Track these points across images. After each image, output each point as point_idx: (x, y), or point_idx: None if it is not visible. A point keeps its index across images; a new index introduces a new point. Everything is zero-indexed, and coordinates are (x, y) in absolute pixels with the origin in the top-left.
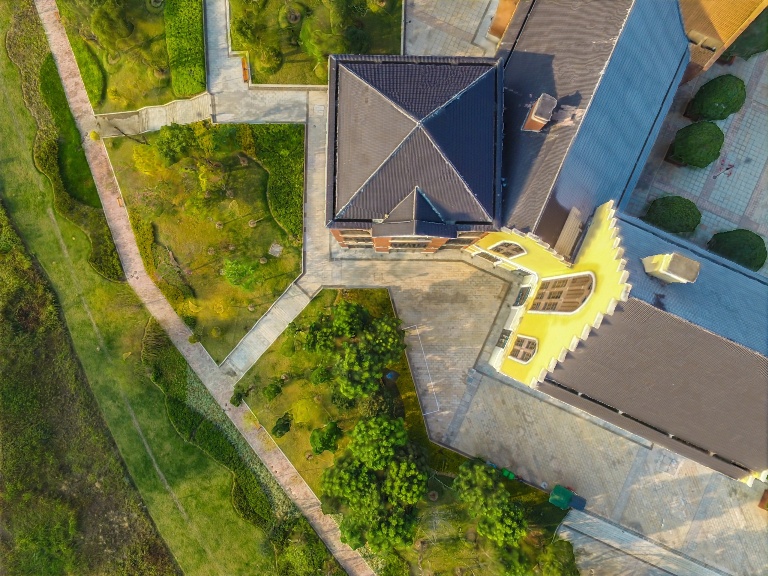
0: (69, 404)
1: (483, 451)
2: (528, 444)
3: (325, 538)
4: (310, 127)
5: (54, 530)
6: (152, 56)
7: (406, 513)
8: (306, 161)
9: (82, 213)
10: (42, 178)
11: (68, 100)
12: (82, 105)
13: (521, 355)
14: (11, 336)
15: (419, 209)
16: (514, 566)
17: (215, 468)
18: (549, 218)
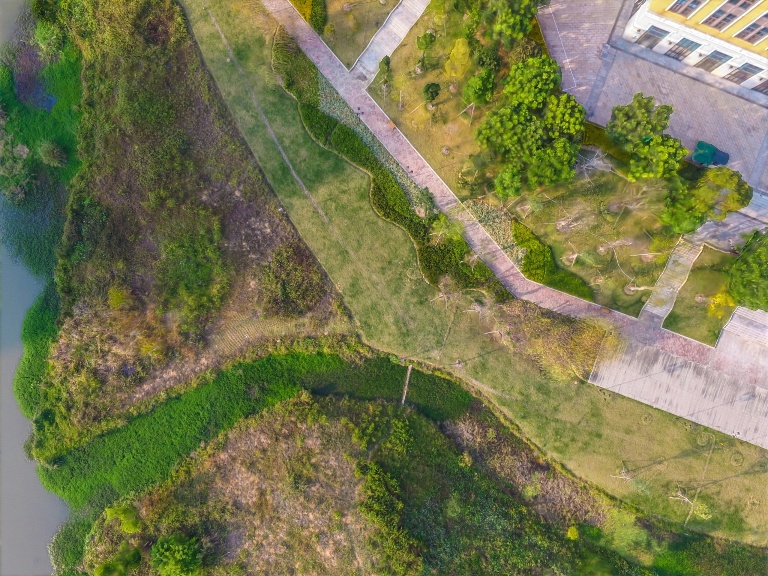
0: (204, 115)
1: None
2: None
3: (464, 233)
4: None
5: (198, 238)
6: None
7: None
8: None
9: None
10: None
11: None
12: None
13: None
14: (143, 47)
15: None
16: (676, 189)
17: (352, 171)
18: None
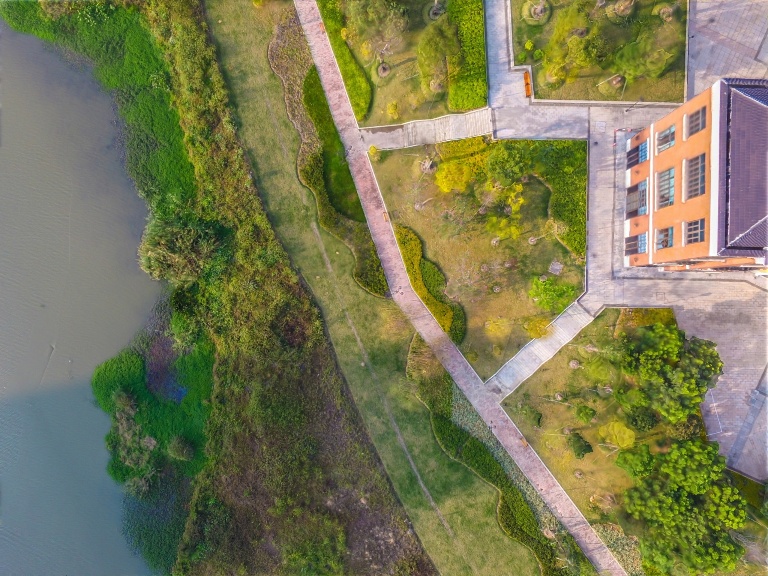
0: (334, 419)
1: (766, 473)
2: None
3: (591, 557)
4: (592, 144)
5: (321, 545)
6: None
7: (729, 538)
8: (588, 178)
9: (347, 227)
10: (306, 192)
11: (332, 113)
12: (346, 118)
13: None
14: (280, 351)
15: None
16: None
17: (480, 485)
18: None
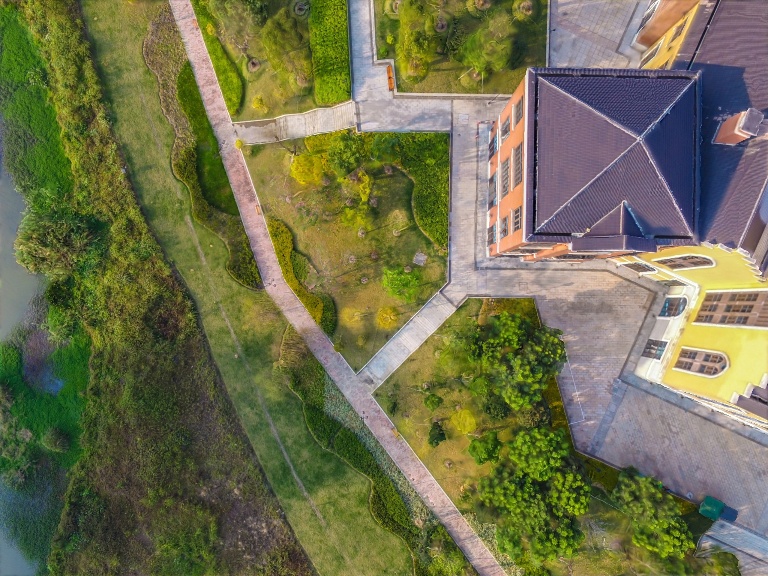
0: (208, 411)
1: (628, 461)
2: (673, 454)
3: (462, 546)
4: (455, 136)
5: (194, 536)
6: (294, 64)
7: (572, 524)
8: (451, 170)
9: (220, 221)
10: (180, 185)
11: (205, 108)
12: (219, 113)
13: (698, 368)
14: (152, 343)
15: (626, 224)
16: None
17: (353, 475)
18: (752, 233)
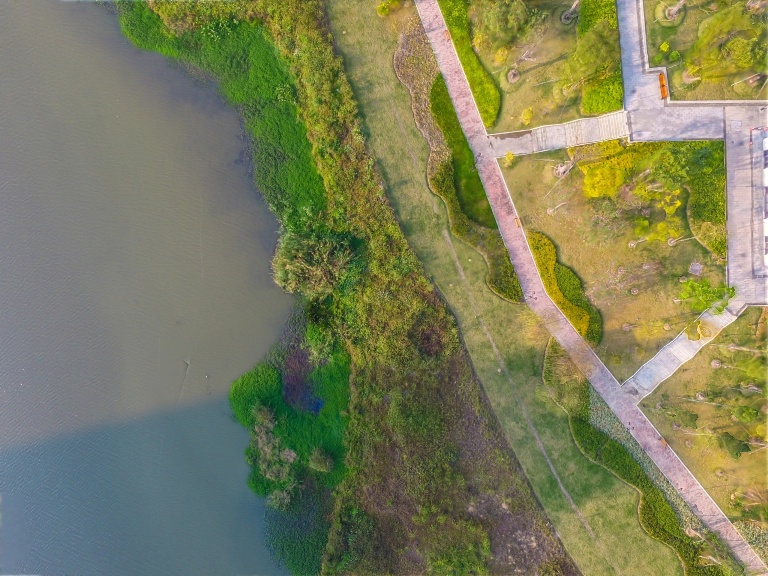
0: (473, 426)
1: None
2: None
3: (732, 554)
4: (728, 143)
5: (465, 551)
6: (559, 74)
7: None
8: (726, 178)
9: (479, 234)
10: (436, 200)
11: (460, 120)
12: (474, 125)
13: None
14: (419, 360)
15: None
16: None
17: (620, 487)
18: None
